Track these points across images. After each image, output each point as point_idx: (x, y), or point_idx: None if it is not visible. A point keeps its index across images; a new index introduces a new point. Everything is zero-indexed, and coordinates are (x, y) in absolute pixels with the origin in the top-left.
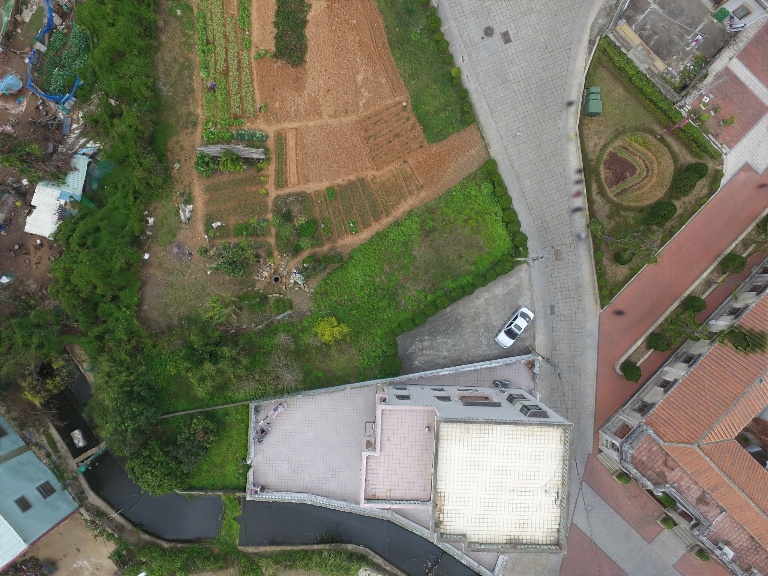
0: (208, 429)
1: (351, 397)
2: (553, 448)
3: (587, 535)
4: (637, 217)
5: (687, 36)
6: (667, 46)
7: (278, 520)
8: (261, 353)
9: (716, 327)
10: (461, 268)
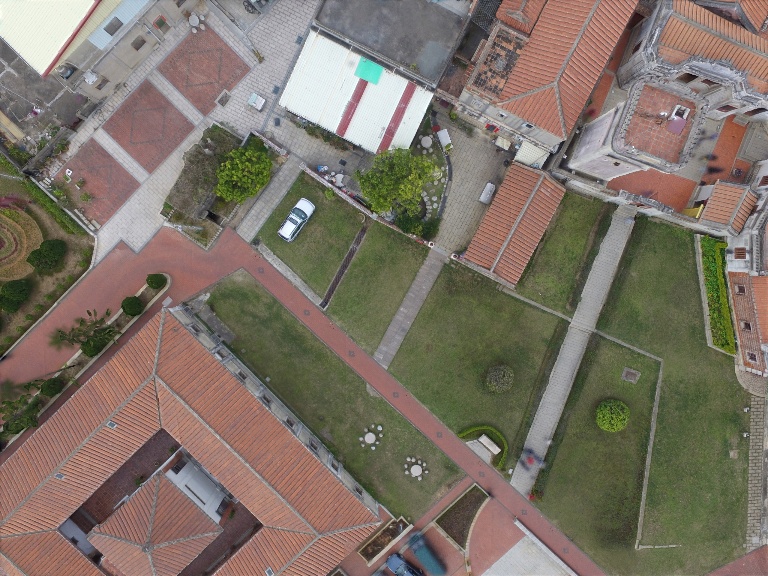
0: None
1: None
2: None
3: None
4: None
5: (46, 103)
6: (25, 113)
7: None
8: None
9: None
10: None
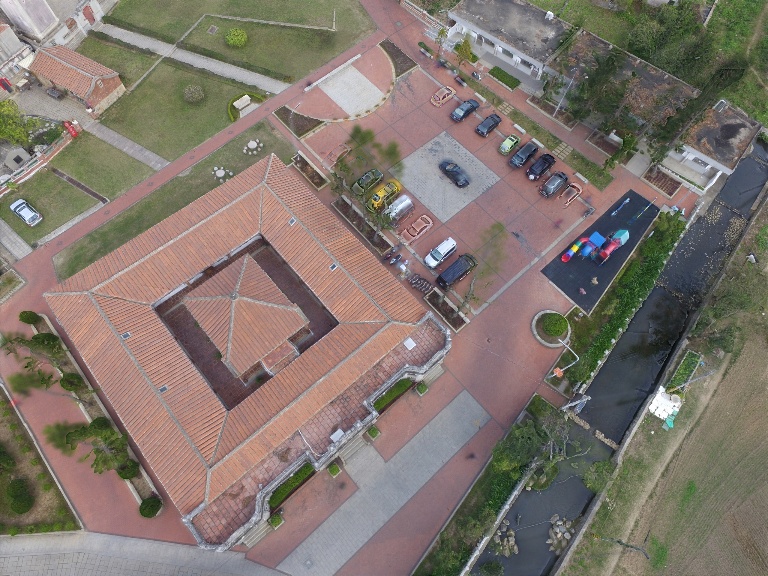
0: None
1: None
2: None
3: (340, 568)
4: None
5: None
6: None
7: None
8: None
9: None
10: None
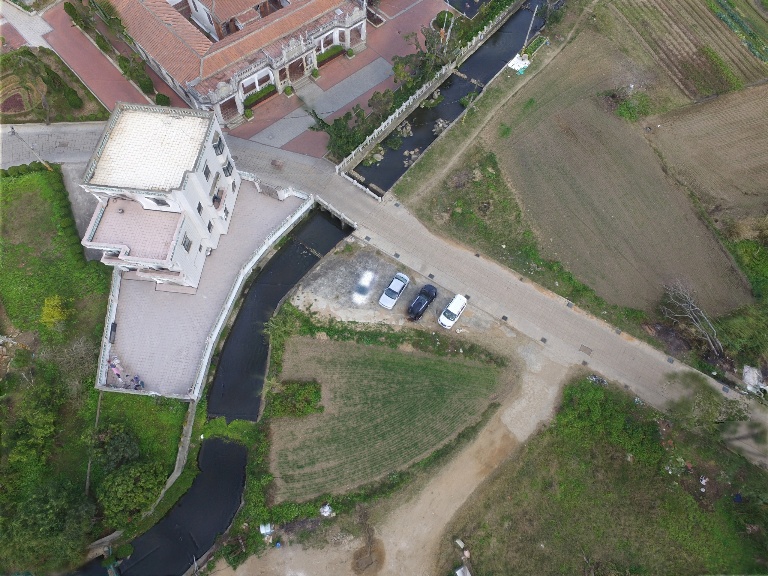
0: (104, 430)
1: (129, 301)
2: (138, 118)
3: (292, 139)
4: (54, 96)
5: None
6: None
7: (237, 380)
8: (59, 381)
9: None
10: (46, 210)
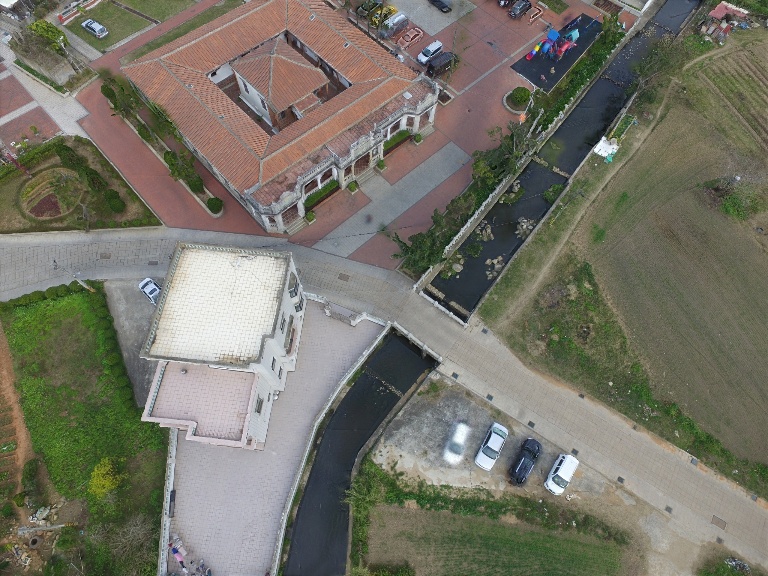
0: None
1: (188, 460)
2: (202, 258)
3: (359, 247)
4: (93, 195)
5: None
6: None
7: (316, 559)
8: (112, 567)
9: (190, 145)
10: (89, 340)
